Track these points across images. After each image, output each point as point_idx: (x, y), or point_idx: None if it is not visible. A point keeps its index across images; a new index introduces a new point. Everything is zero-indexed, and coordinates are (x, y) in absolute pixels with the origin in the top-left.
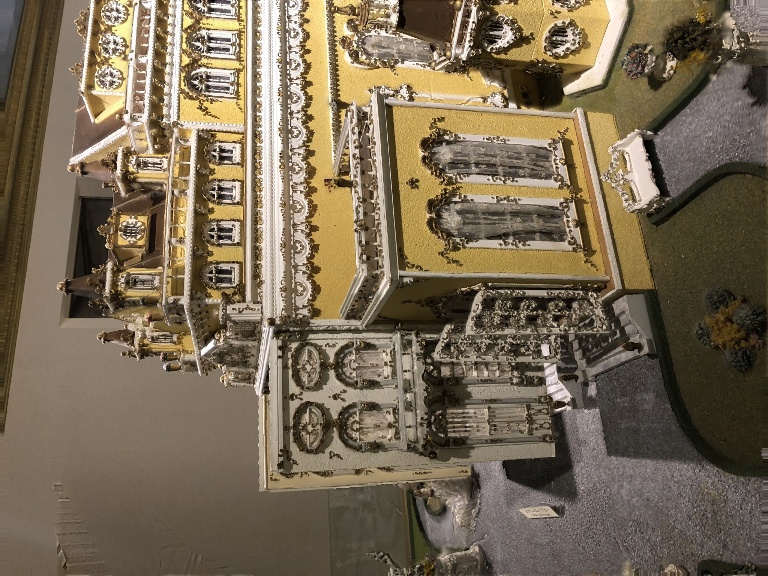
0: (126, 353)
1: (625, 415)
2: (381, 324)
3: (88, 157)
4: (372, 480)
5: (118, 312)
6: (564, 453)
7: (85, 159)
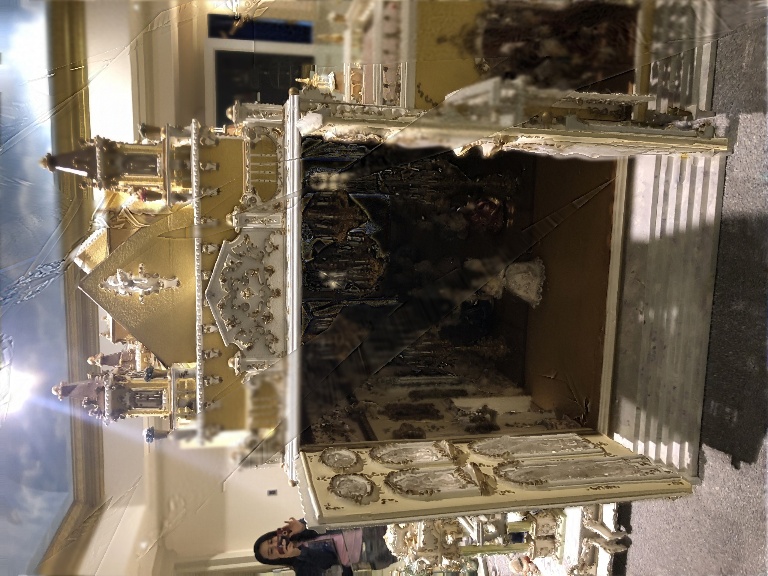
0: (91, 399)
1: (761, 51)
2: (426, 109)
3: (93, 245)
4: (517, 498)
5: (99, 273)
6: (764, 232)
7: (89, 249)
